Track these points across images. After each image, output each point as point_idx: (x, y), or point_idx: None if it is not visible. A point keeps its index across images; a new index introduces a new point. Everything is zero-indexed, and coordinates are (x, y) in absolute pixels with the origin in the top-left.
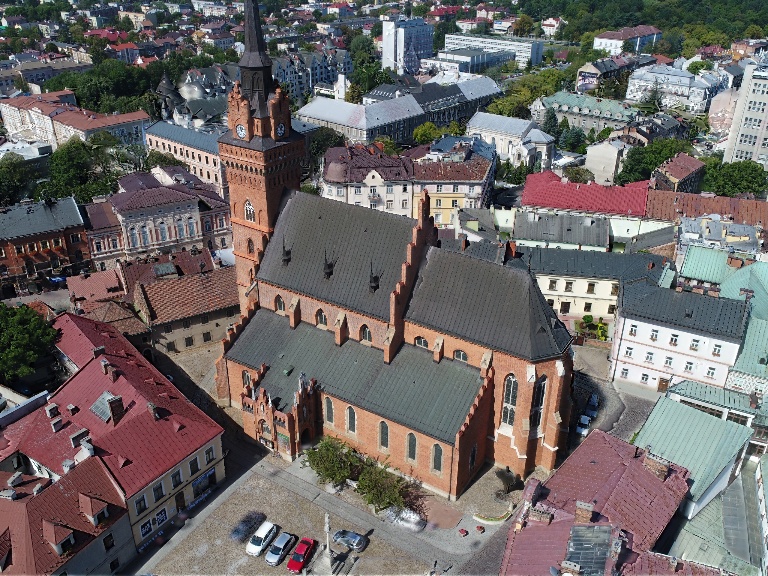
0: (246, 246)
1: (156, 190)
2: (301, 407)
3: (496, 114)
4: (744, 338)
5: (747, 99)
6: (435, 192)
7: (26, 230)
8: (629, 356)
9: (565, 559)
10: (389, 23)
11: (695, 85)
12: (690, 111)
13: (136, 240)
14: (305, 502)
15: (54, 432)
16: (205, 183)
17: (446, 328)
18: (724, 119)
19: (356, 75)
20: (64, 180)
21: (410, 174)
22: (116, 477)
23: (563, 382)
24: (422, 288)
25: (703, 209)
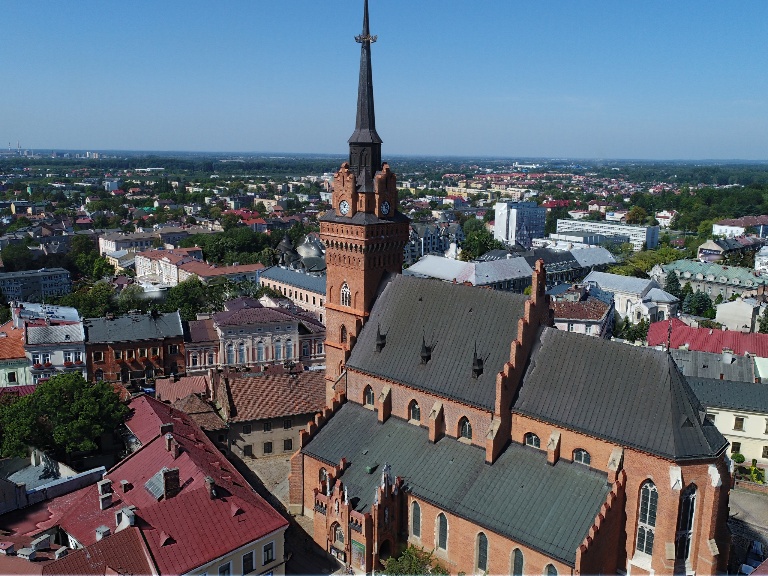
0: (338, 334)
1: (259, 310)
2: (382, 508)
3: (612, 273)
4: None
5: None
6: None
7: (128, 336)
8: None
9: None
10: (502, 204)
11: None
12: None
13: (232, 357)
14: None
15: (101, 509)
16: None
17: (563, 420)
18: None
19: (467, 242)
20: None
21: None
22: (154, 556)
23: None
24: (534, 374)
25: None
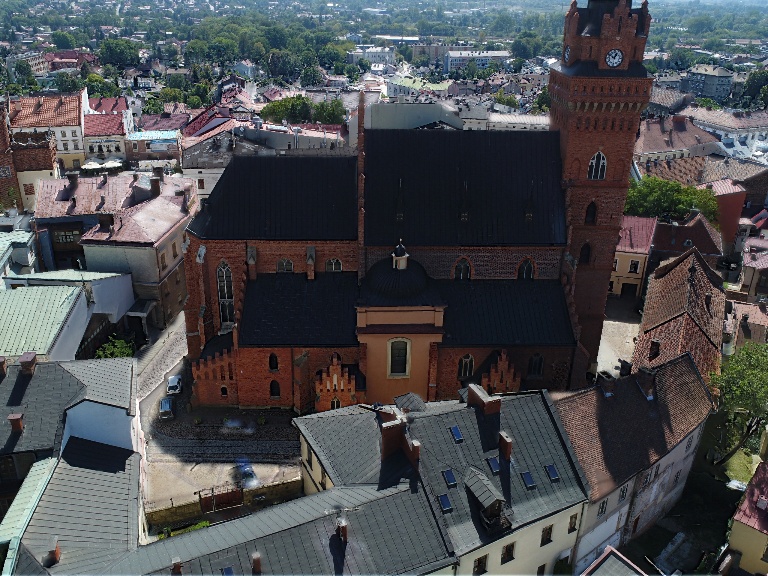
0: None
1: None
2: None
3: None
4: None
5: None
6: None
7: None
8: None
9: None
10: None
11: None
12: None
13: None
14: None
15: None
16: None
17: None
18: None
19: None
20: None
21: None
22: None
23: None
24: None
25: None
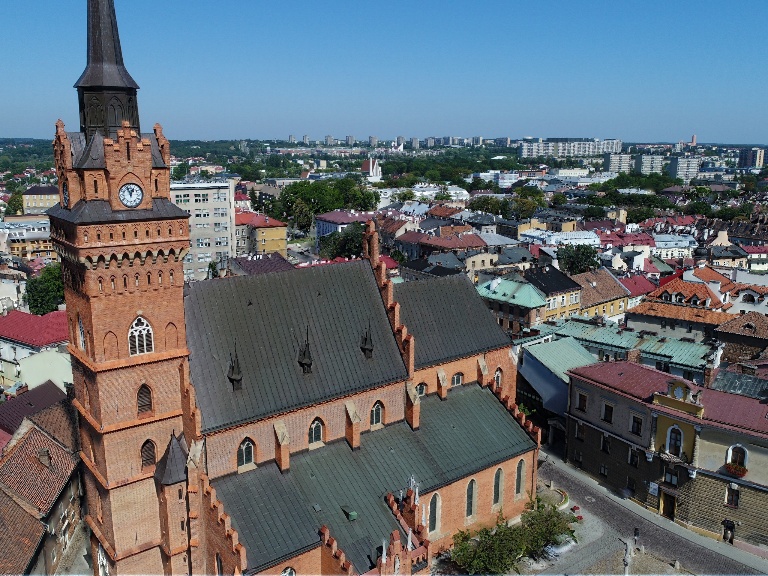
0: (134, 404)
1: None
2: None
3: None
4: None
5: None
6: None
7: None
8: None
9: (750, 396)
10: None
11: None
12: None
13: None
14: None
15: None
16: None
17: (443, 357)
18: None
19: None
20: None
21: None
22: None
23: None
24: None
25: None
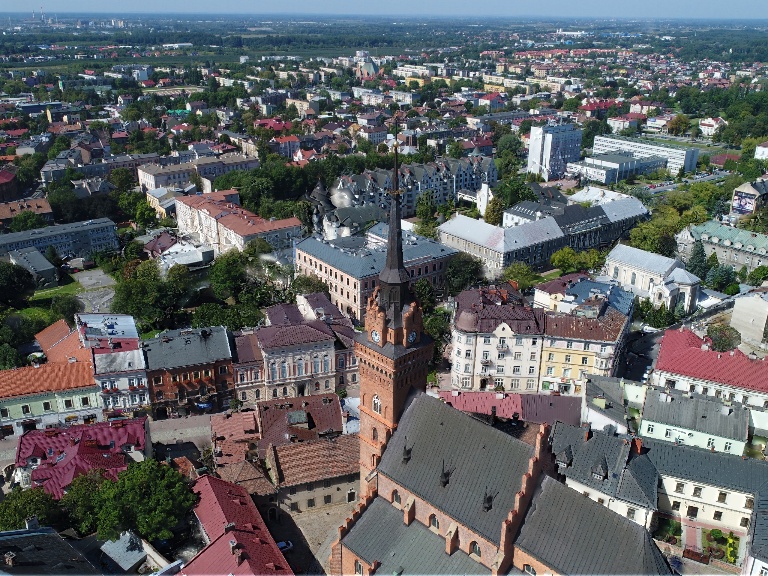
0: (371, 433)
1: (298, 328)
2: None
3: (638, 248)
4: None
5: None
6: (565, 348)
7: (183, 361)
8: None
9: None
10: (537, 128)
11: None
12: None
13: (275, 374)
14: None
15: None
16: (343, 316)
17: (555, 565)
18: None
19: (499, 189)
20: (221, 290)
21: (541, 328)
22: None
23: None
24: (535, 516)
25: None
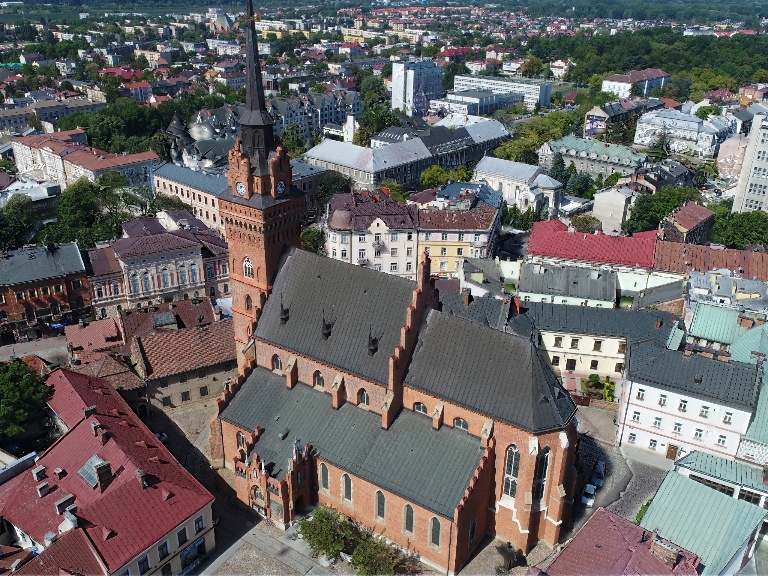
0: (244, 302)
1: (159, 236)
2: (295, 474)
3: (503, 159)
4: (756, 405)
5: (756, 149)
6: (440, 240)
7: (27, 276)
8: (636, 421)
9: None
10: (399, 65)
11: (703, 130)
12: (699, 156)
13: (138, 286)
14: (297, 575)
15: (40, 497)
16: None
17: (446, 395)
18: (733, 165)
19: (365, 117)
20: (71, 221)
21: (415, 222)
22: (99, 550)
23: (567, 453)
24: (422, 352)
25: (712, 261)
